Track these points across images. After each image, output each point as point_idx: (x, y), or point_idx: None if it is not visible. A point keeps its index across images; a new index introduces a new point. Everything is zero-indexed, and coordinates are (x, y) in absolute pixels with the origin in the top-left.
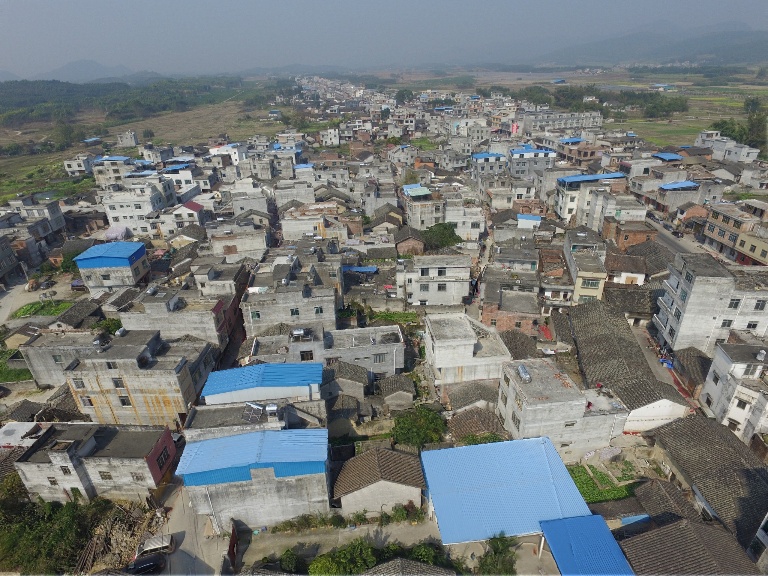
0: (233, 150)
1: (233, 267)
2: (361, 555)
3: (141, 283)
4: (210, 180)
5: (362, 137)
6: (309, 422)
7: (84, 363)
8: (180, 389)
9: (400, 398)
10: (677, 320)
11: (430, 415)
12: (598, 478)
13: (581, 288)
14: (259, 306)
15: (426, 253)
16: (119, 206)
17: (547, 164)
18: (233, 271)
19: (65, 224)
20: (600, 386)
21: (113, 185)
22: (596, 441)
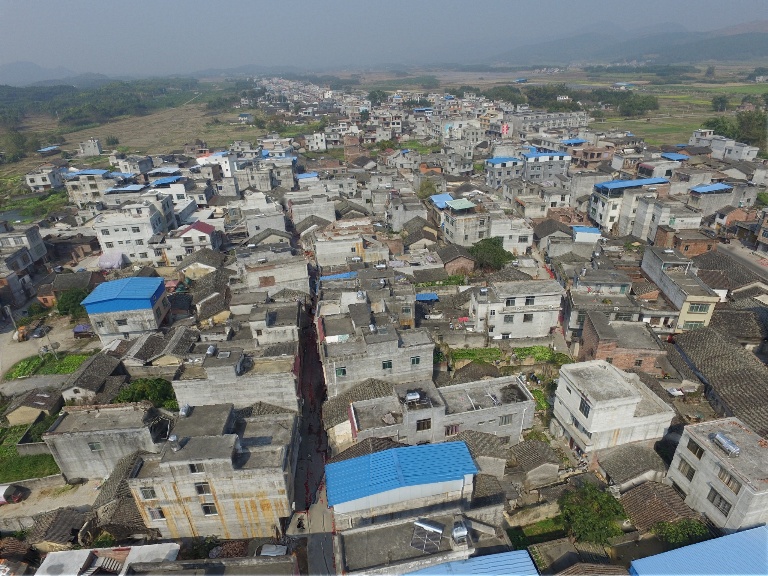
0: (223, 159)
1: (287, 306)
2: None
3: (165, 327)
4: (206, 194)
5: (351, 141)
6: (482, 533)
7: (149, 462)
8: (285, 489)
9: (544, 471)
10: None
11: None
12: None
13: (687, 313)
14: (346, 361)
15: (476, 272)
16: (113, 230)
17: (562, 167)
18: (289, 312)
19: (46, 252)
20: None
21: (97, 204)
22: None
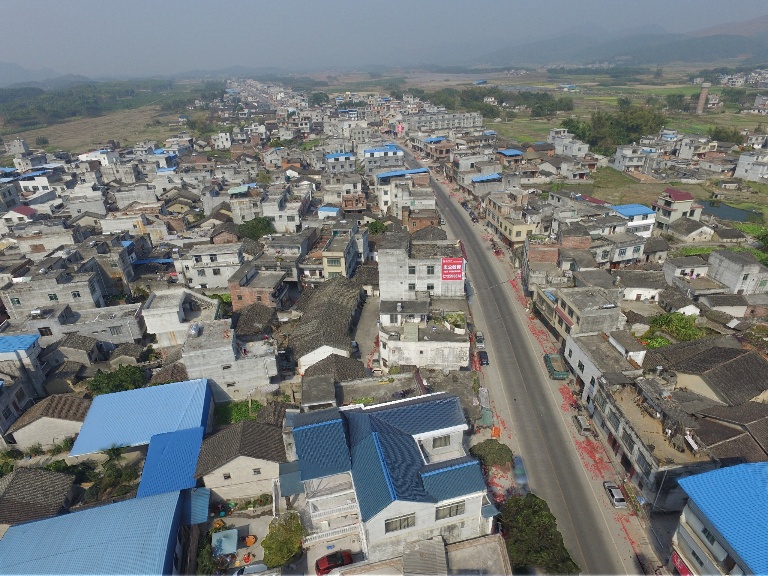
0: (102, 156)
1: (21, 263)
2: (0, 470)
3: None
4: (67, 185)
5: (252, 140)
6: (3, 379)
7: None
8: None
9: (124, 362)
10: None
11: (130, 371)
12: (253, 408)
13: (328, 266)
14: (17, 293)
15: None
16: None
17: (397, 162)
18: None
19: None
20: (266, 338)
21: None
22: (257, 380)
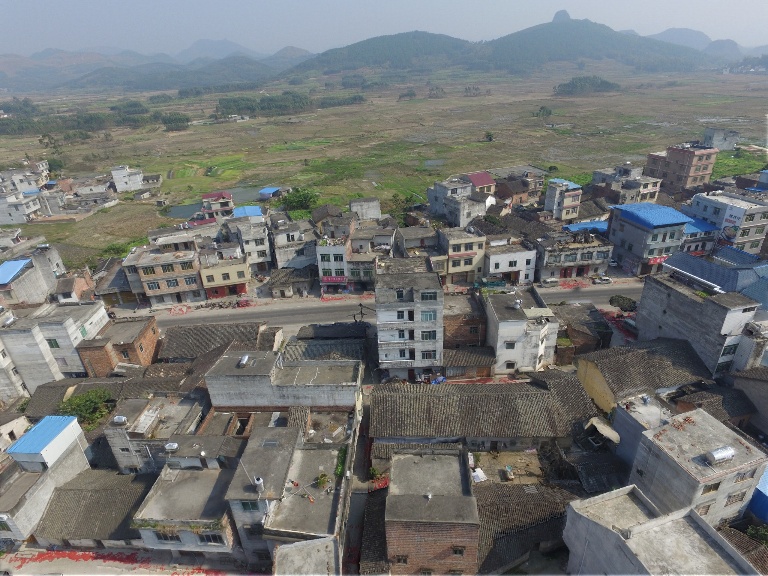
0: None
1: None
2: None
3: None
4: None
5: None
6: None
7: None
8: None
9: None
10: (433, 340)
11: None
12: None
13: None
14: None
15: None
16: None
17: None
18: None
19: None
20: None
21: None
22: None
